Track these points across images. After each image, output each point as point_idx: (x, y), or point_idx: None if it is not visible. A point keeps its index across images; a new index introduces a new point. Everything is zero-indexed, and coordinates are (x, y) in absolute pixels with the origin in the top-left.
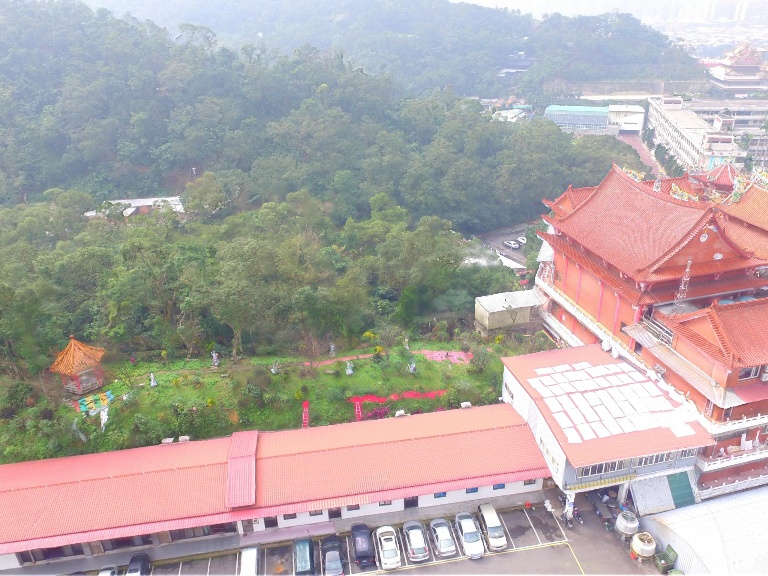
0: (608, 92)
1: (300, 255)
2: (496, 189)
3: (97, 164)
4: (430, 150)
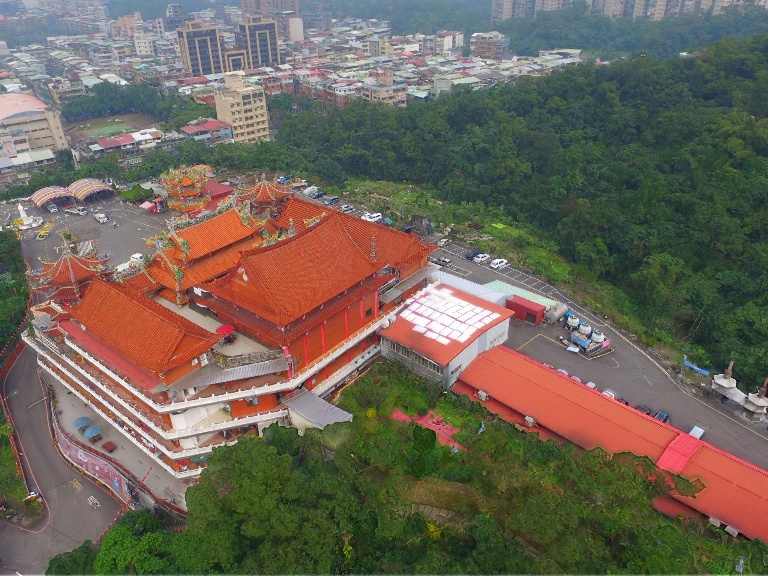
0: None
1: None
2: None
3: None
4: None
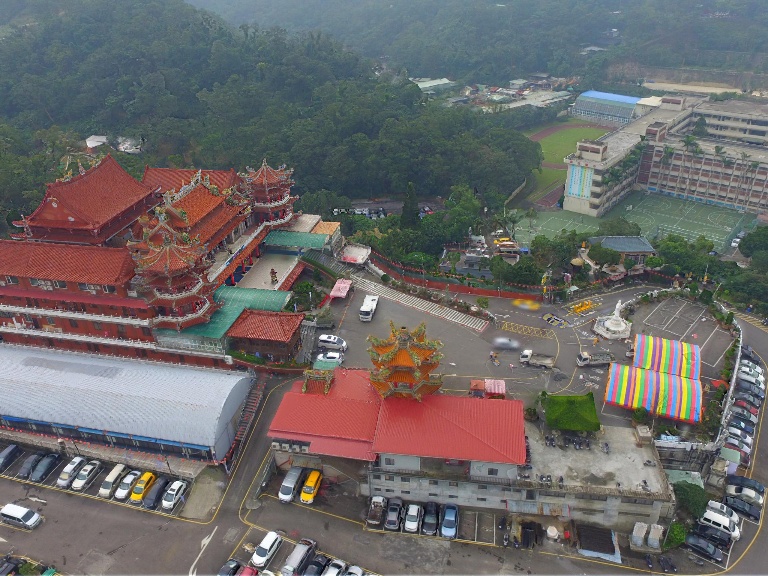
0: (684, 81)
1: (10, 183)
2: (323, 165)
3: (97, 109)
4: (295, 126)
